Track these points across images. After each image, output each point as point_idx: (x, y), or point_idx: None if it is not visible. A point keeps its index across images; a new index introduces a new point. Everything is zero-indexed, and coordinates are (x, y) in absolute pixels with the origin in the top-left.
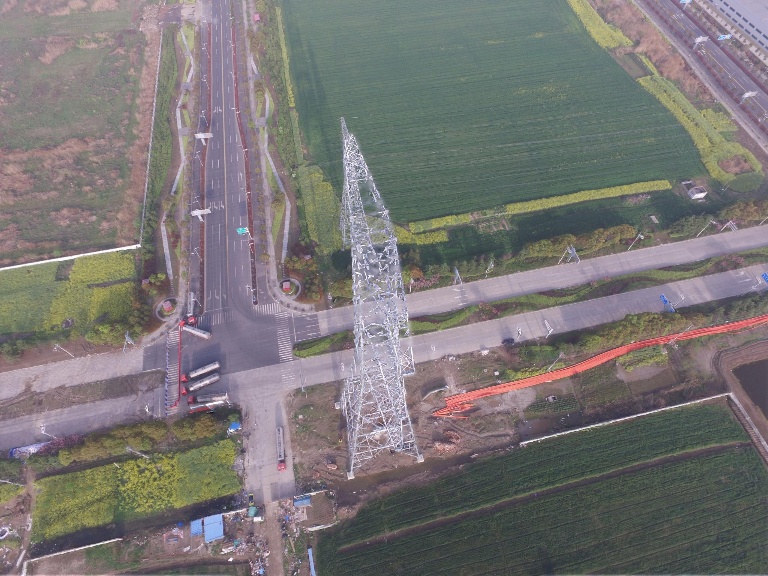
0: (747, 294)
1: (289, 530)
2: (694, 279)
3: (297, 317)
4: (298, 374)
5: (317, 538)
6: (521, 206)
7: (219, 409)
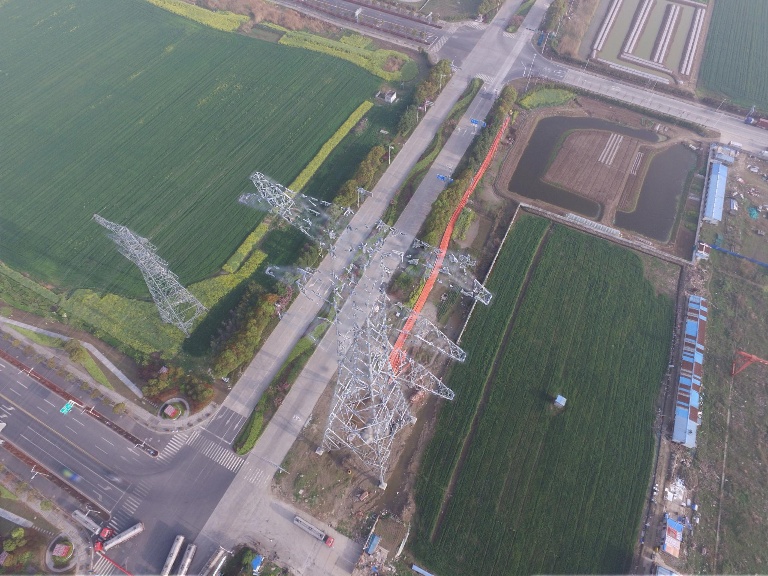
0: (474, 139)
1: (385, 575)
2: (441, 153)
3: (209, 425)
4: (262, 465)
5: (409, 553)
6: (294, 187)
7: (225, 568)
